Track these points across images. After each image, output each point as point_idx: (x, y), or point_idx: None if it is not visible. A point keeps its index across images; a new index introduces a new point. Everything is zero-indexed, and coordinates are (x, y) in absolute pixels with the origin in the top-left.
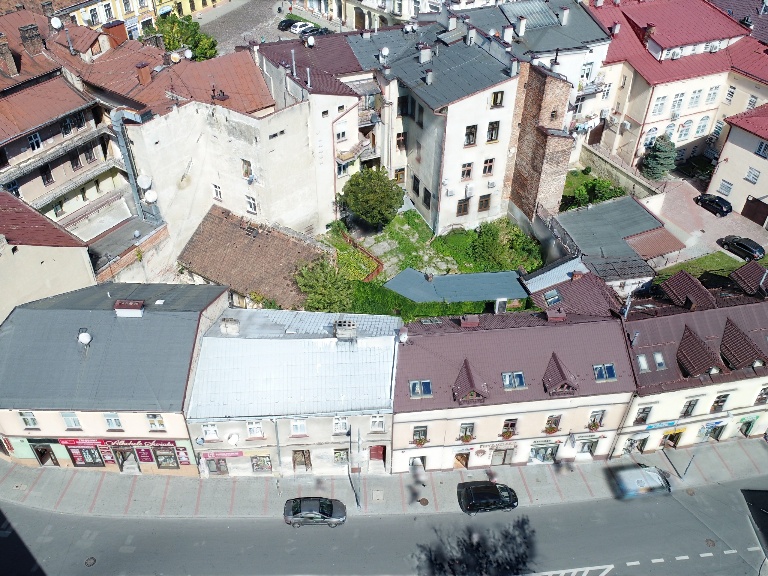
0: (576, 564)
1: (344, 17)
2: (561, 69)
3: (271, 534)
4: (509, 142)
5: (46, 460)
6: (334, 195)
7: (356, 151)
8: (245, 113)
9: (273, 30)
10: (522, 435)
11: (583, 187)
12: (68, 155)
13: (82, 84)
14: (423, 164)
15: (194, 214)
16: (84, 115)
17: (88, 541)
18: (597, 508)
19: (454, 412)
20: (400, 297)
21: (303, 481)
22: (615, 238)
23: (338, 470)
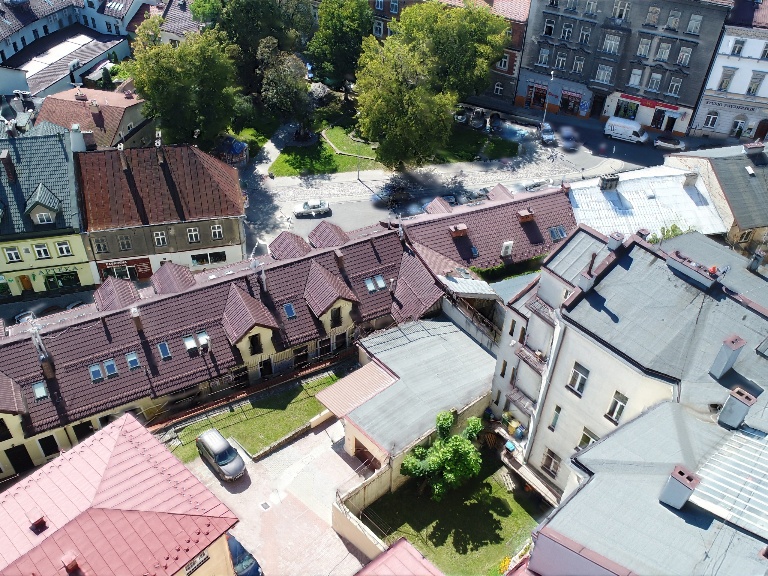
0: None
1: None
2: None
3: None
4: None
5: None
6: None
7: None
8: None
9: None
10: None
11: (471, 448)
12: None
13: None
14: None
15: None
16: None
17: None
18: None
19: None
20: None
21: None
22: (410, 375)
23: None
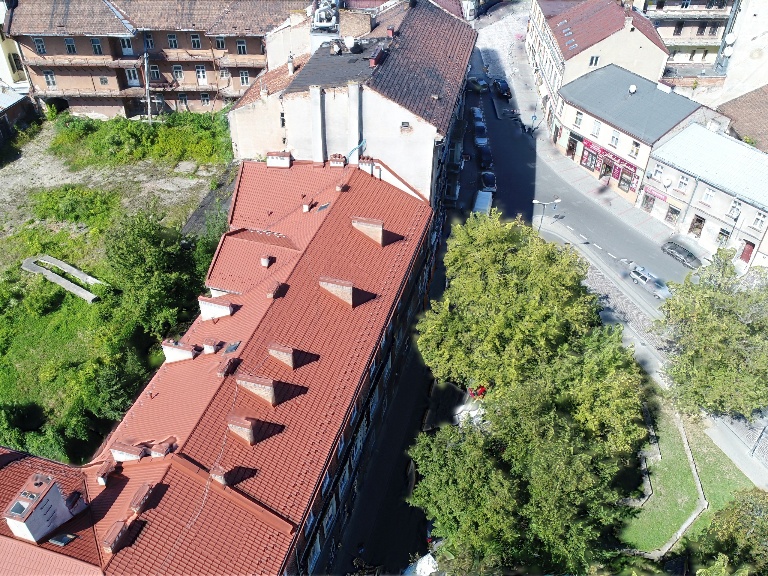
0: None
1: None
2: None
3: (648, 246)
4: None
5: (570, 155)
6: None
7: None
8: None
9: None
10: None
11: None
12: (700, 22)
13: None
14: None
15: (750, 82)
16: (728, 0)
17: (562, 190)
18: None
19: None
20: None
21: (689, 241)
22: None
23: (715, 249)
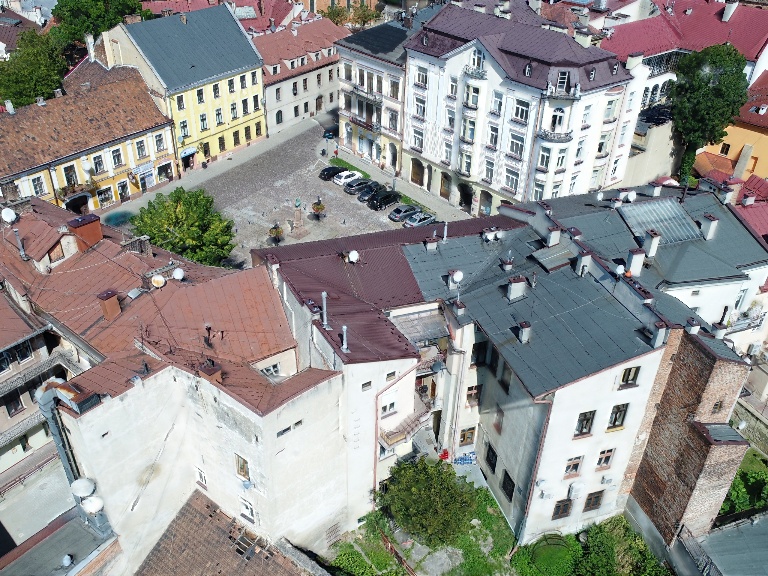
0: None
1: (399, 167)
2: (706, 303)
3: None
4: (639, 427)
5: None
6: (372, 482)
7: (409, 428)
8: (242, 400)
9: (313, 179)
10: None
11: (739, 479)
12: (2, 398)
13: (29, 304)
14: (505, 439)
15: (164, 510)
16: (31, 343)
17: None
18: None
19: None
20: None
21: None
22: None
23: None
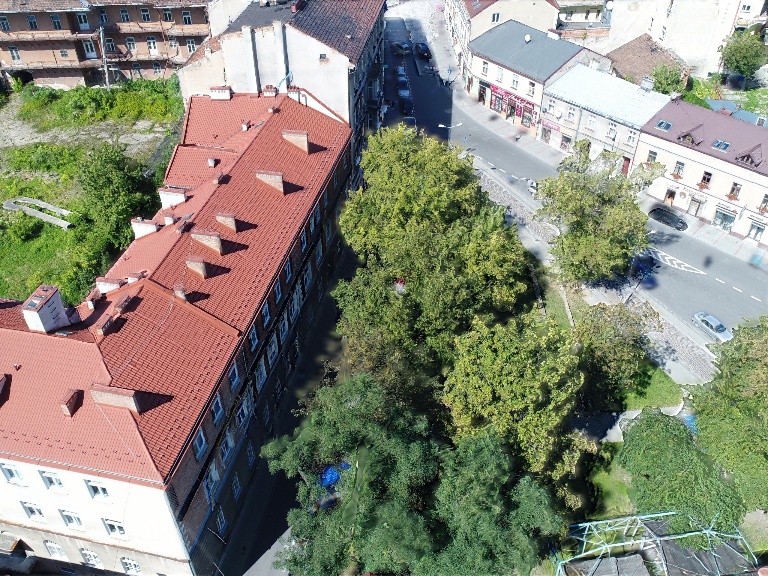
0: (685, 261)
1: None
2: None
3: (546, 169)
4: None
5: (481, 101)
6: None
7: (752, 22)
8: None
9: None
10: (712, 192)
11: None
12: None
13: None
14: None
15: (631, 32)
16: None
17: (474, 130)
18: (730, 258)
19: (675, 147)
20: (707, 105)
21: None
22: None
23: None
